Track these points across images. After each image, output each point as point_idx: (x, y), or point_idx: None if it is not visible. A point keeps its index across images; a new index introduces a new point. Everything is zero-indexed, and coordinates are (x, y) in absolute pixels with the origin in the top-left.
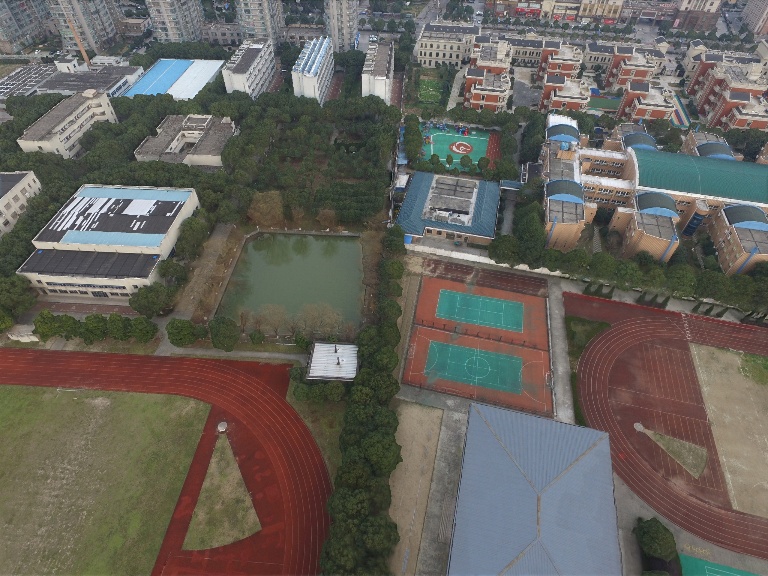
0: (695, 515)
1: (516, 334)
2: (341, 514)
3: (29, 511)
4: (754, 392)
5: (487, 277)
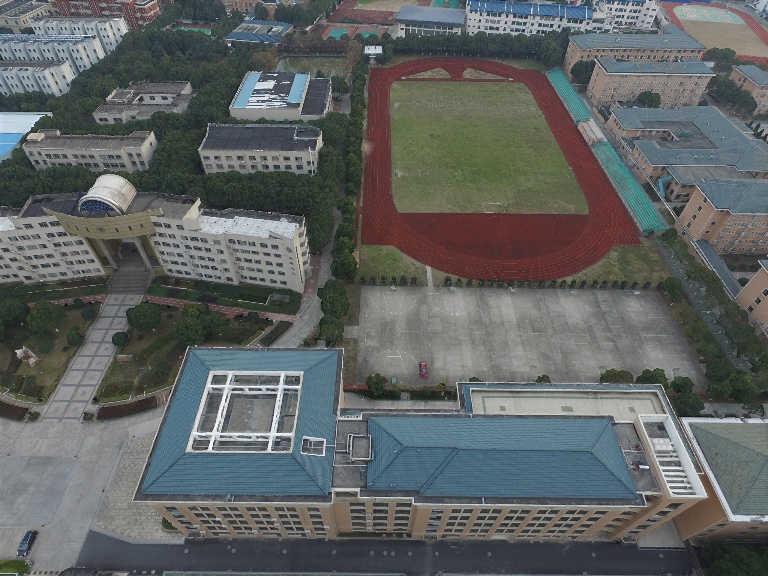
0: None
1: None
2: (438, 38)
3: None
4: (374, 4)
5: None
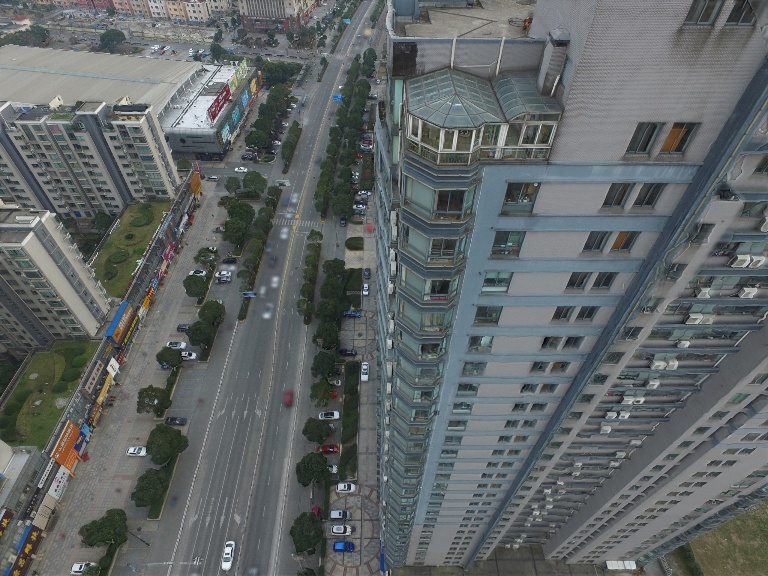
0: None
1: None
2: None
3: None
4: None
5: None
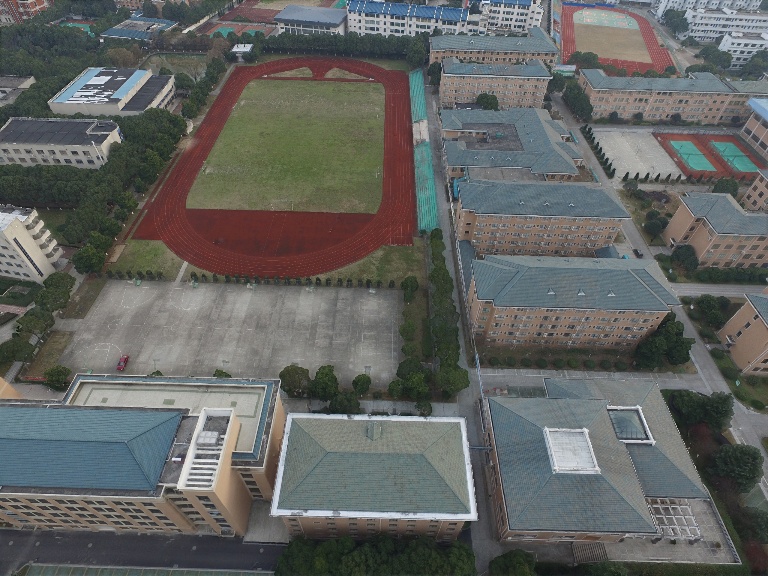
0: None
1: (237, 29)
2: None
3: (294, 105)
4: None
5: (201, 31)
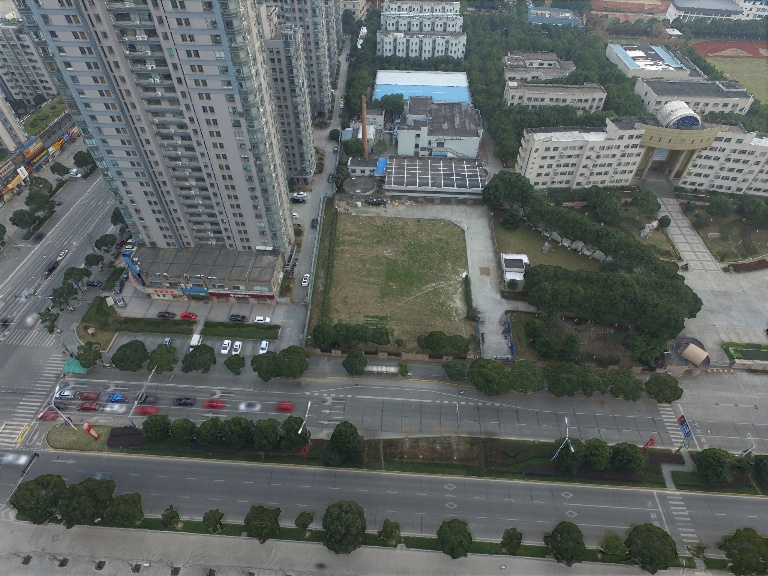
0: (668, 7)
1: None
2: None
3: None
4: None
5: None
